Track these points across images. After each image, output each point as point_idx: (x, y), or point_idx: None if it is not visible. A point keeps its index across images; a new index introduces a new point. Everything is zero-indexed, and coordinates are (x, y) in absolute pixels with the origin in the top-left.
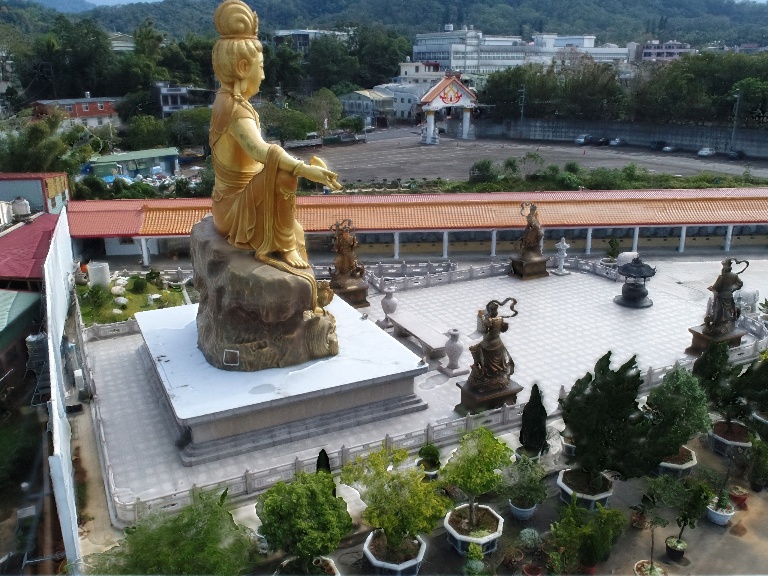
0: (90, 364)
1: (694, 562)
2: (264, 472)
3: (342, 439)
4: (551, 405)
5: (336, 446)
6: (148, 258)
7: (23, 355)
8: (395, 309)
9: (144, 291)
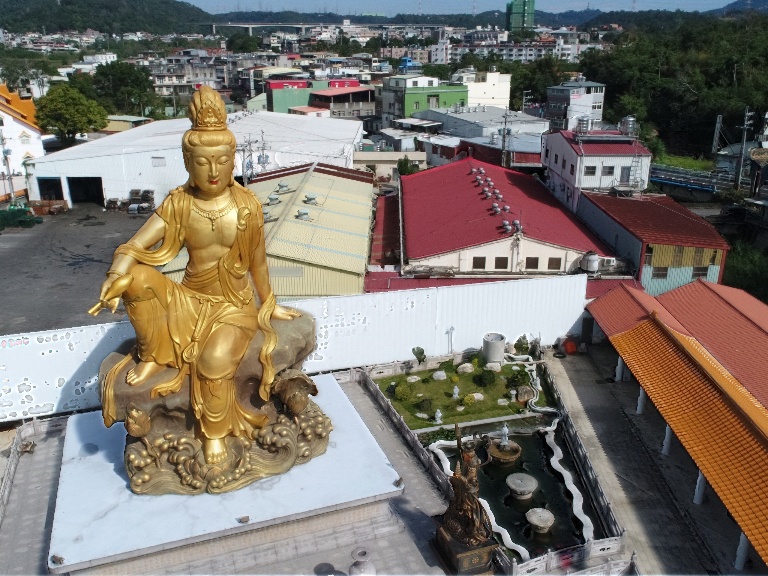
0: None
1: None
2: (5, 481)
3: (47, 538)
4: None
5: (37, 534)
6: (623, 373)
7: (309, 356)
8: None
9: (489, 386)
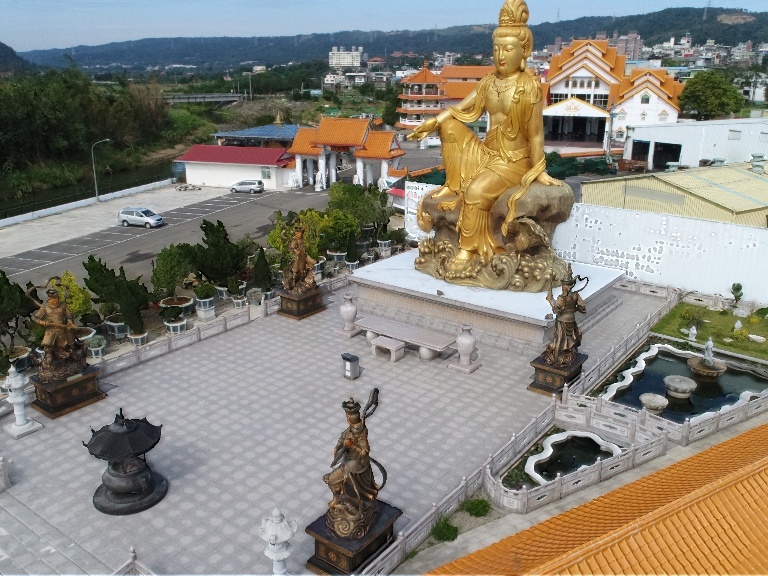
0: (619, 289)
1: (181, 288)
2: None
3: None
4: (257, 323)
5: None
6: None
7: None
8: (463, 353)
9: None
